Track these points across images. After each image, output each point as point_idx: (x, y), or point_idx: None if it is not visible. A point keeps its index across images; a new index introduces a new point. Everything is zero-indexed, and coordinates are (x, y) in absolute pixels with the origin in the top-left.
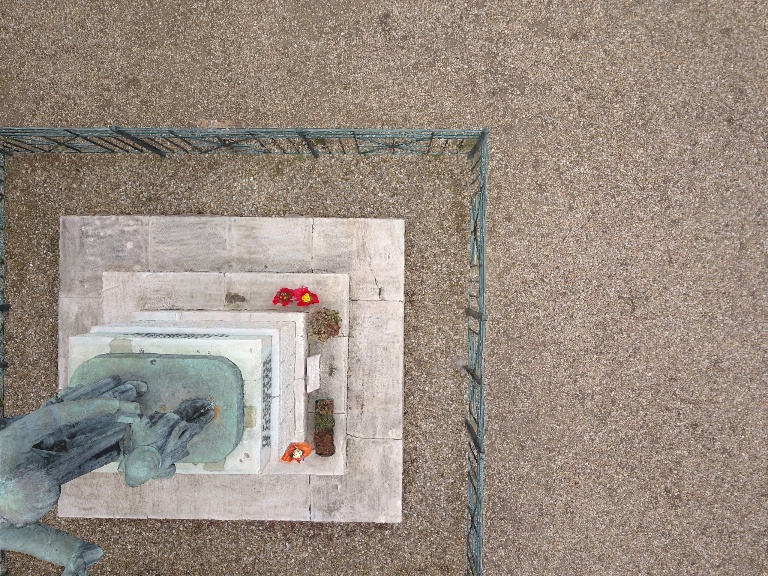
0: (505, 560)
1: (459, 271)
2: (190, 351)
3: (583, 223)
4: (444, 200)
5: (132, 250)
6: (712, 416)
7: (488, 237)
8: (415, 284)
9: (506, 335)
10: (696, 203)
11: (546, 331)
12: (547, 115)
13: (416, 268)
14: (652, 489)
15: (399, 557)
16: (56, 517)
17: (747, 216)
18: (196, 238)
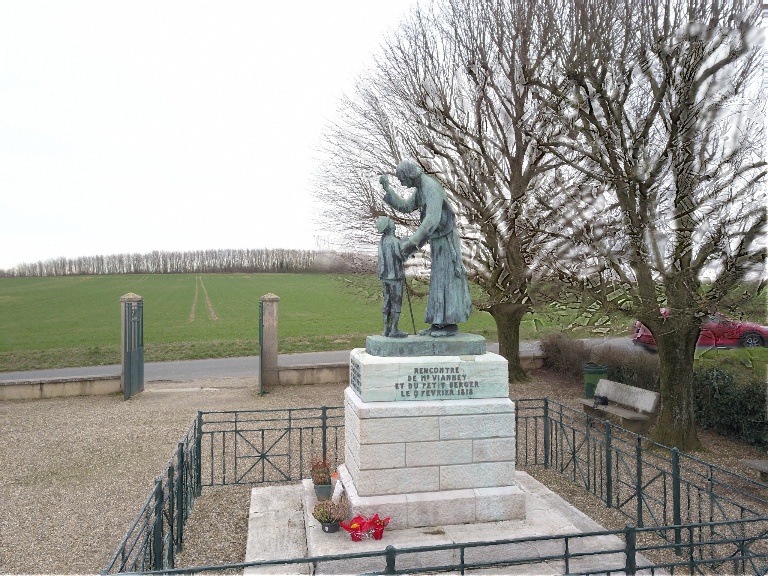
0: None
1: None
2: None
3: None
4: None
5: None
6: None
7: None
8: None
9: None
10: None
11: None
12: None
13: None
14: None
15: None
16: None
17: None
18: None
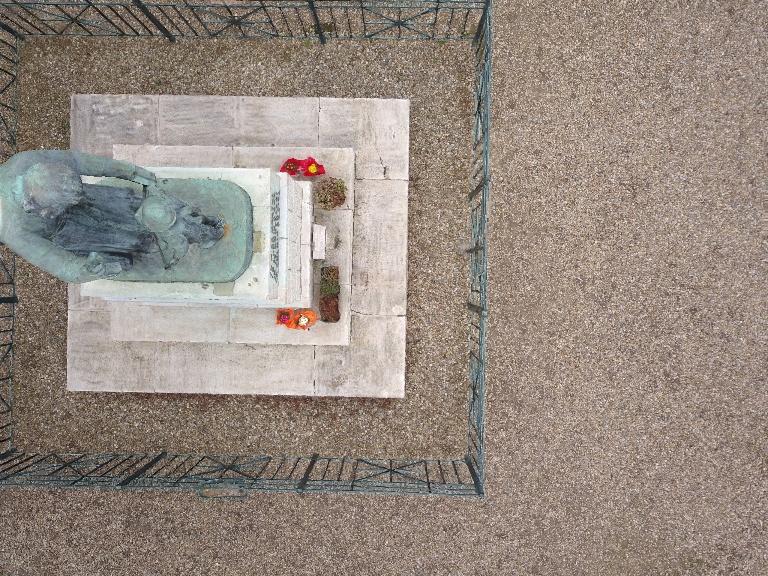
0: (506, 442)
1: (463, 156)
2: (201, 177)
3: (585, 110)
4: (449, 86)
5: (142, 128)
6: (711, 301)
7: (492, 123)
8: (419, 168)
9: (508, 220)
10: (697, 92)
11: (548, 217)
12: (551, 4)
13: (420, 152)
14: (651, 373)
15: (401, 437)
16: (65, 395)
17: (747, 105)
18: (205, 117)
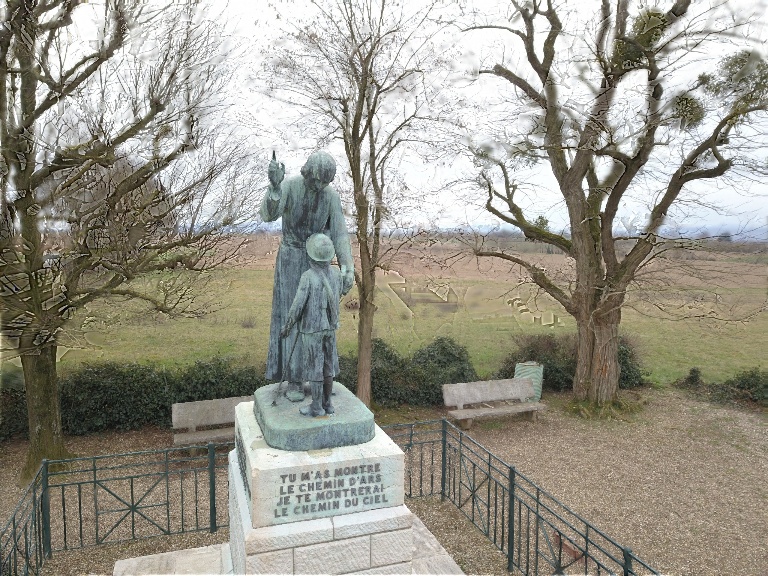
0: None
1: None
2: None
3: None
4: None
5: None
6: None
7: None
8: None
9: None
10: None
11: None
12: None
13: None
14: None
15: None
16: (108, 575)
17: None
18: None
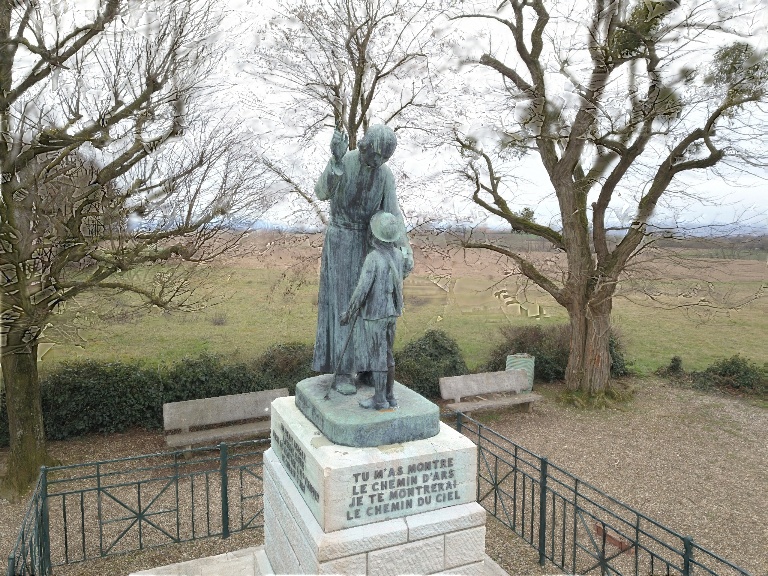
0: None
1: None
2: None
3: None
4: None
5: None
6: None
7: None
8: None
9: None
10: None
11: None
12: None
13: None
14: None
15: None
16: None
17: None
18: None
